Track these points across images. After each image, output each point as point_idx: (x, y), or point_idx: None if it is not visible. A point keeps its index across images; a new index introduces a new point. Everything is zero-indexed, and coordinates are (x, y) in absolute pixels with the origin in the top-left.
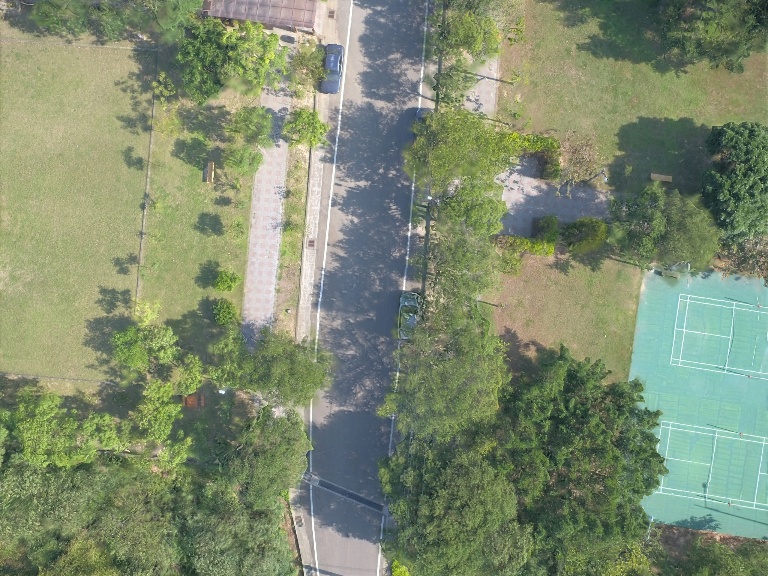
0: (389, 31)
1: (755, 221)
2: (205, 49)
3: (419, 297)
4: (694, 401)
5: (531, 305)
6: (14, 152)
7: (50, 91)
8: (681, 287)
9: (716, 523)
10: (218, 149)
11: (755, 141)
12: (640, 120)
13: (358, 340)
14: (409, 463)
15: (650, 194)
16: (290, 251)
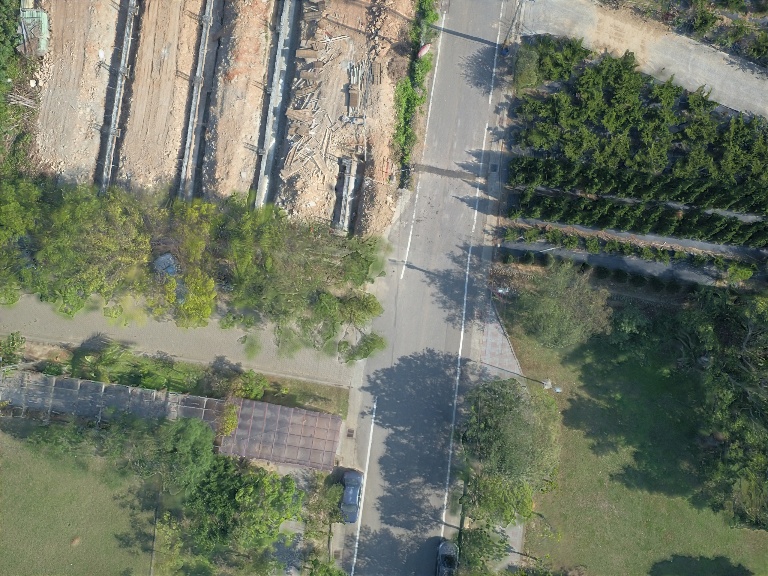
0: (412, 453)
1: None
2: (215, 502)
3: None
4: None
5: None
6: (2, 568)
7: (43, 502)
8: None
9: None
10: (225, 573)
11: None
12: (675, 558)
13: None
14: None
15: None
16: None
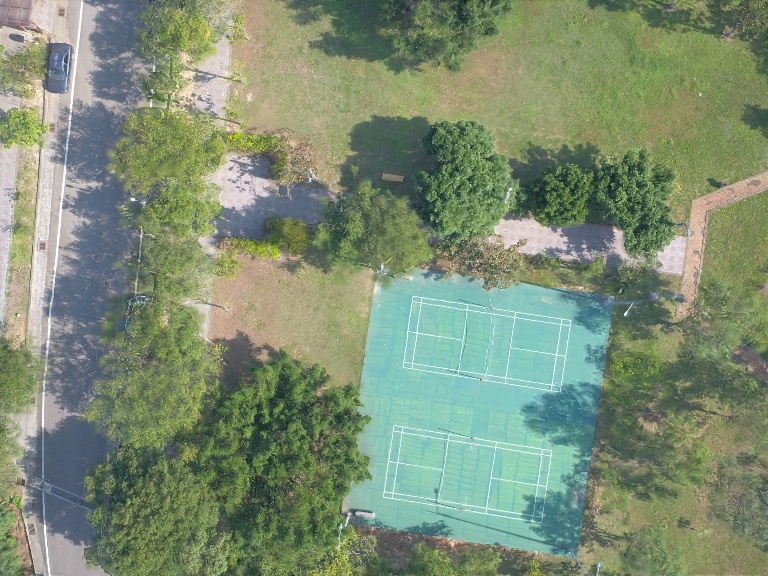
0: (120, 29)
1: (466, 222)
2: None
3: (130, 301)
4: (426, 405)
5: (262, 308)
6: None
7: None
8: (414, 289)
9: (448, 529)
10: None
11: (464, 140)
12: (373, 119)
13: (89, 344)
14: (116, 470)
15: (360, 195)
16: (20, 254)
